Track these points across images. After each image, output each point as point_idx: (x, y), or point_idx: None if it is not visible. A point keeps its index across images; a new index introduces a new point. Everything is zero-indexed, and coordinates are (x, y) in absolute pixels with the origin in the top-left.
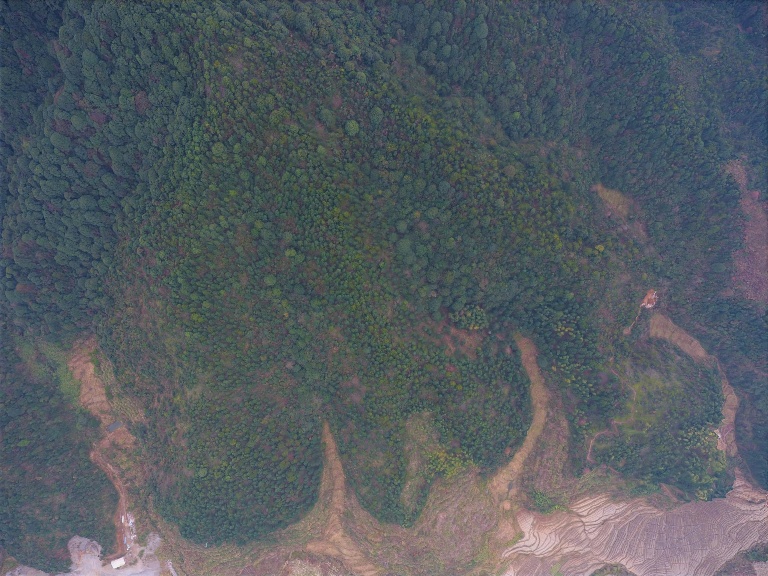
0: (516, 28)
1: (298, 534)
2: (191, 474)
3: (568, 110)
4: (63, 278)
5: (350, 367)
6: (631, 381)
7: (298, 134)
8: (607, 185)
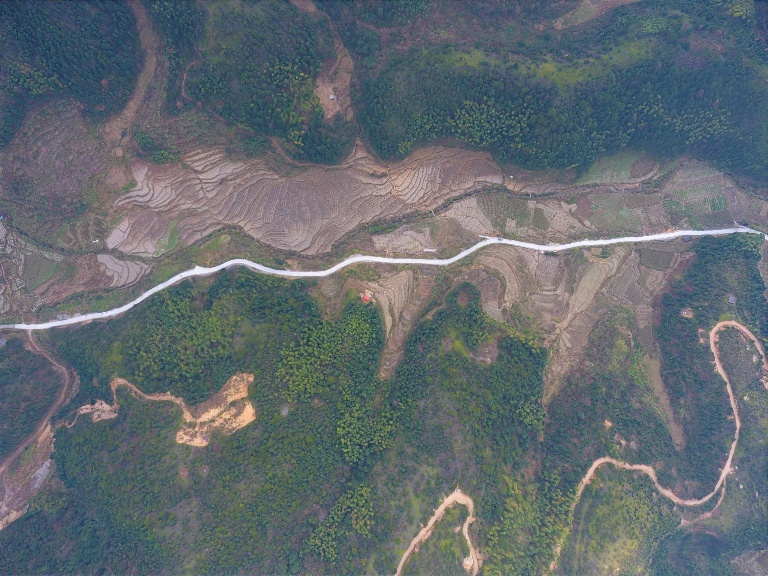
0: None
1: None
2: None
3: None
4: None
5: None
6: (207, 0)
7: None
8: None
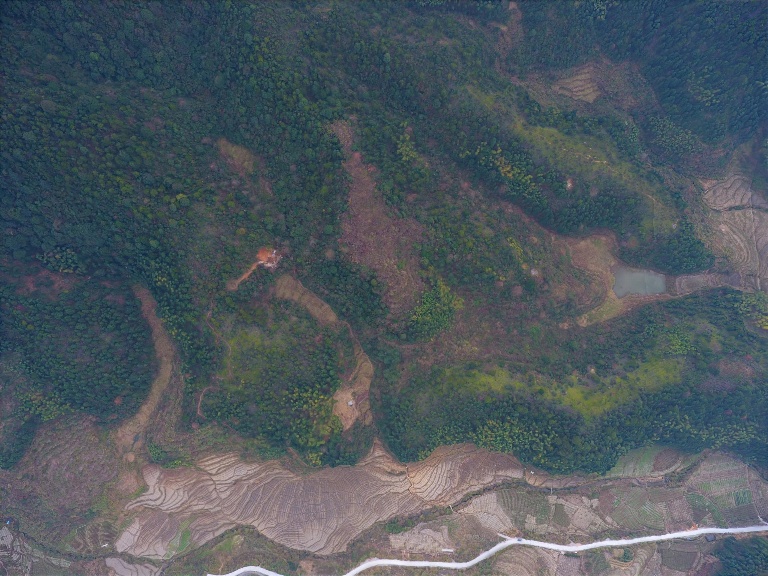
0: None
1: None
2: None
3: (159, 56)
4: None
5: None
6: (226, 336)
7: None
8: (229, 140)
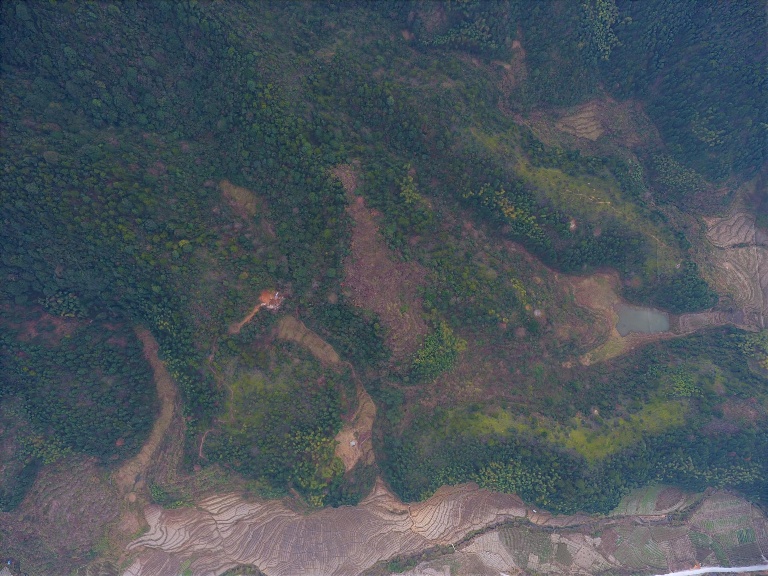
0: (66, 13)
1: None
2: None
3: (161, 101)
4: None
5: None
6: (228, 380)
7: None
8: (232, 182)
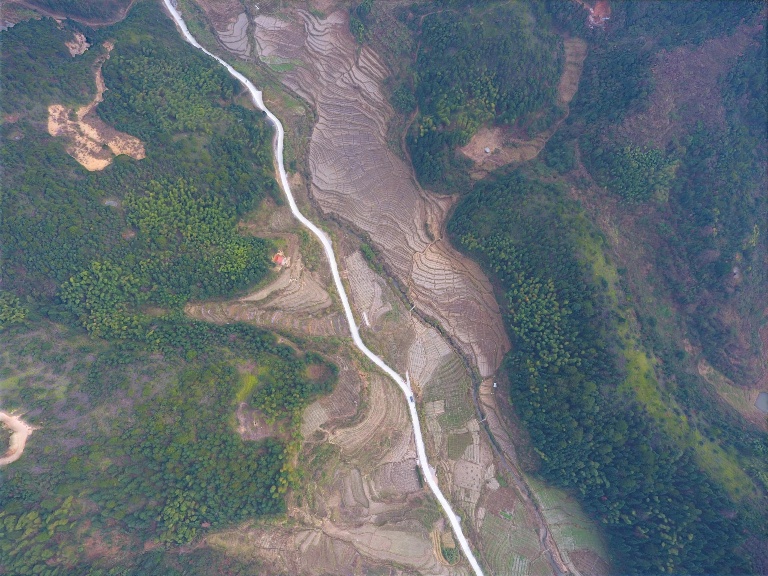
0: None
1: None
2: None
3: None
4: None
5: None
6: None
7: None
8: None
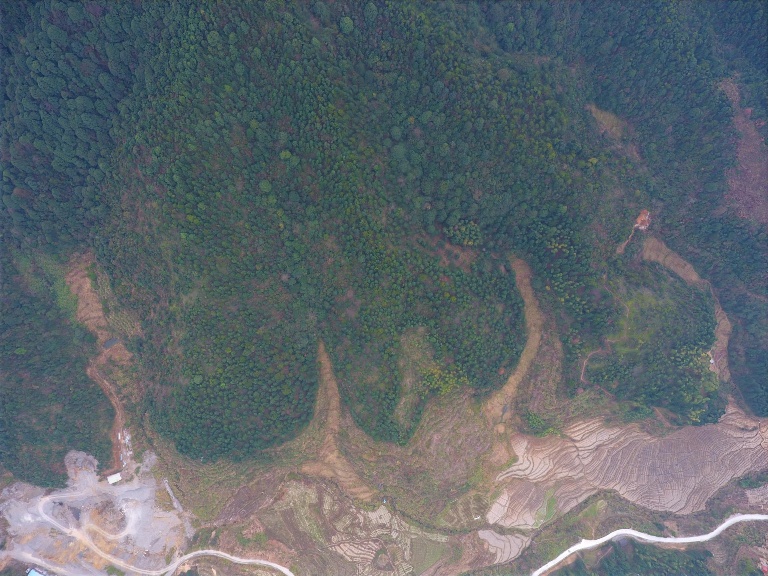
0: None
1: (293, 453)
2: (187, 382)
3: (562, 24)
4: (60, 185)
5: (345, 280)
6: (624, 298)
7: (293, 24)
8: (601, 106)
